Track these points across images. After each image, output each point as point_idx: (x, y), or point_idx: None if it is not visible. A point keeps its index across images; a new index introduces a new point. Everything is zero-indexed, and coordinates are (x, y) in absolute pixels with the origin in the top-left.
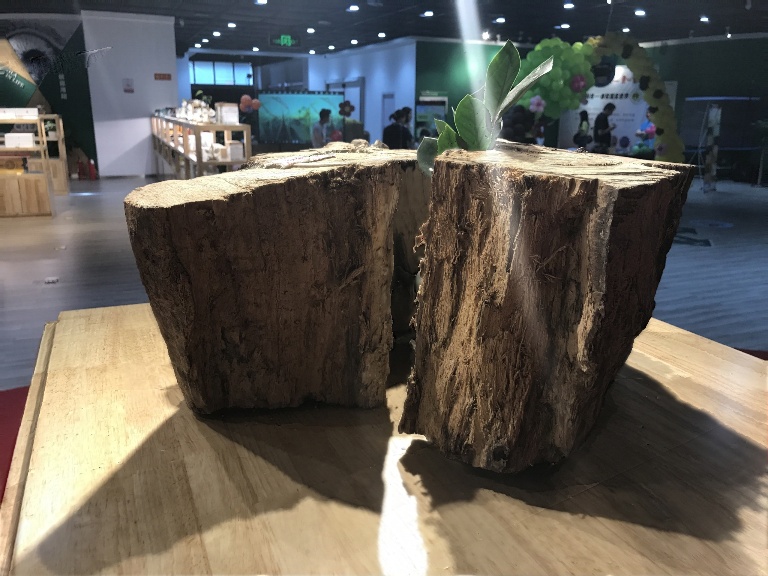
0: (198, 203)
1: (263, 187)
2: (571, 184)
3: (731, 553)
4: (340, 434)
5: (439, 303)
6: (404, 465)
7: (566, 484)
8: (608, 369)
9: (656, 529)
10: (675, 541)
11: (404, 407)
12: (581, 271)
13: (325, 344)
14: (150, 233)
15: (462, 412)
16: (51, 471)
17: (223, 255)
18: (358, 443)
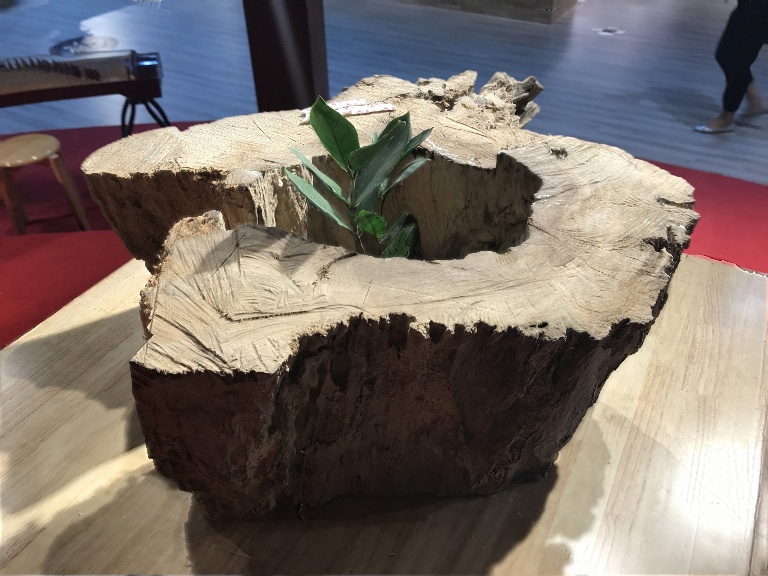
0: (111, 174)
1: (164, 171)
2: None
3: None
4: None
5: None
6: None
7: (233, 536)
8: (213, 487)
9: None
10: None
11: None
12: None
13: None
14: None
15: None
16: (90, 298)
17: (149, 212)
18: None
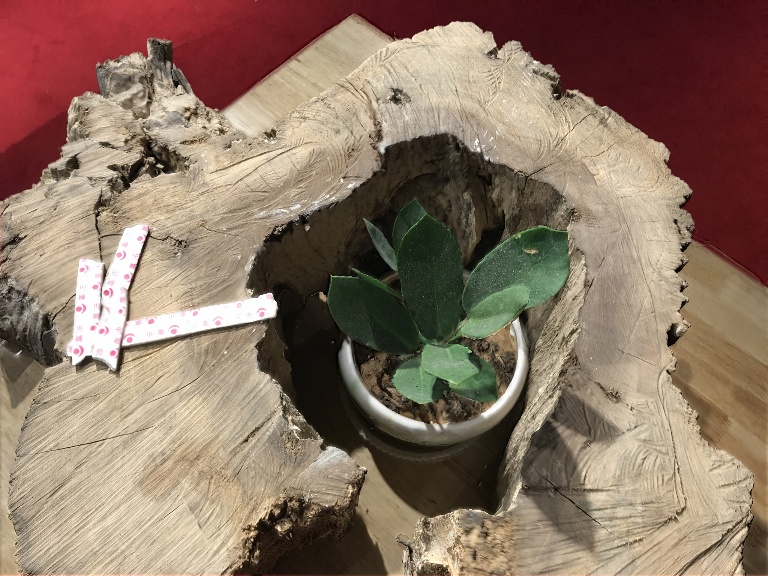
0: None
1: None
2: None
3: None
4: None
5: None
6: None
7: None
8: None
9: None
10: None
11: None
12: None
13: None
14: None
15: None
16: None
17: None
18: None
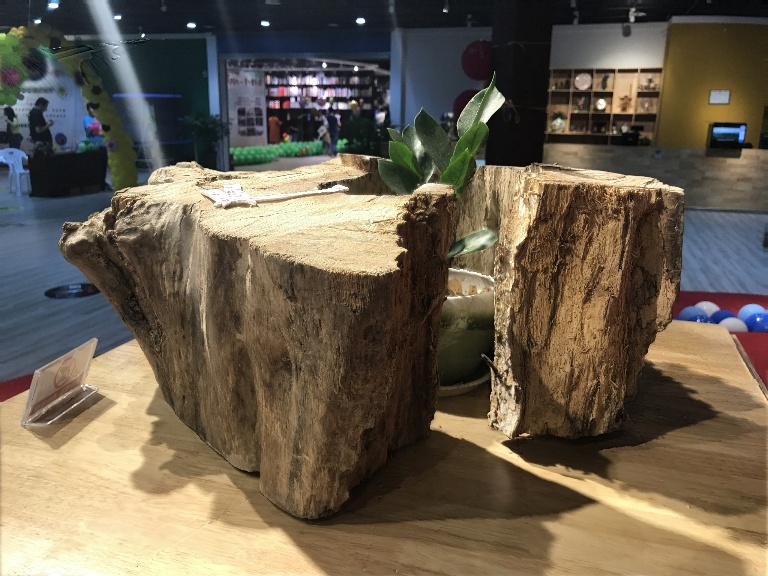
0: None
1: None
2: (648, 194)
3: (729, 419)
4: (454, 467)
5: (533, 311)
6: (537, 463)
7: None
8: None
9: (693, 425)
10: (708, 426)
11: (520, 413)
12: (646, 258)
13: (399, 387)
14: (386, 304)
15: (586, 395)
16: None
17: None
18: (479, 466)
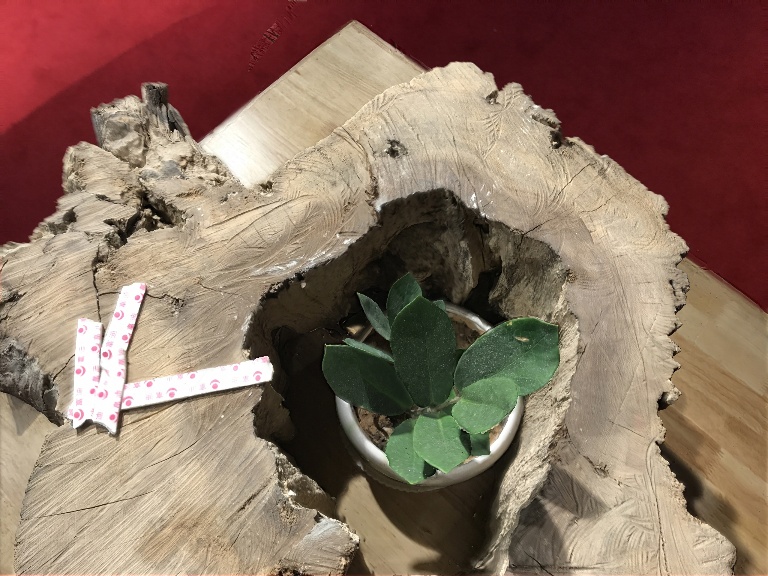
0: None
1: None
2: None
3: None
4: None
5: None
6: None
7: None
8: None
9: None
10: None
11: None
12: None
13: None
14: None
15: None
16: None
17: None
18: None
